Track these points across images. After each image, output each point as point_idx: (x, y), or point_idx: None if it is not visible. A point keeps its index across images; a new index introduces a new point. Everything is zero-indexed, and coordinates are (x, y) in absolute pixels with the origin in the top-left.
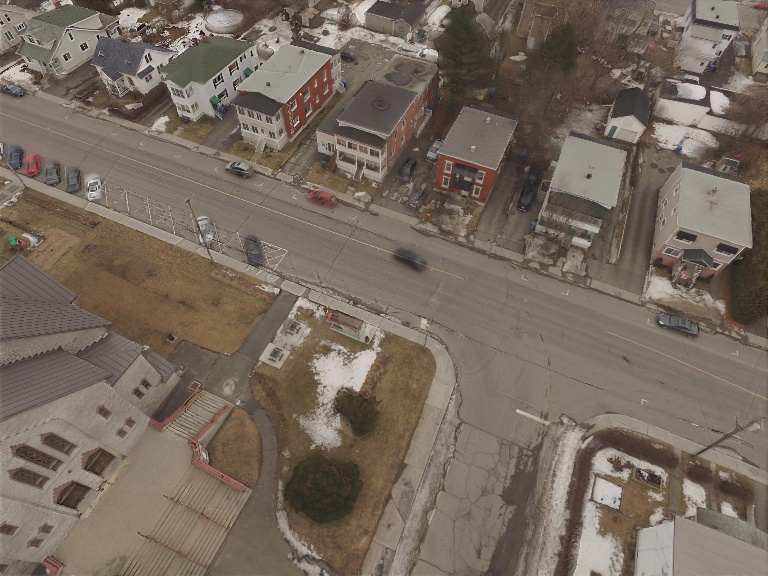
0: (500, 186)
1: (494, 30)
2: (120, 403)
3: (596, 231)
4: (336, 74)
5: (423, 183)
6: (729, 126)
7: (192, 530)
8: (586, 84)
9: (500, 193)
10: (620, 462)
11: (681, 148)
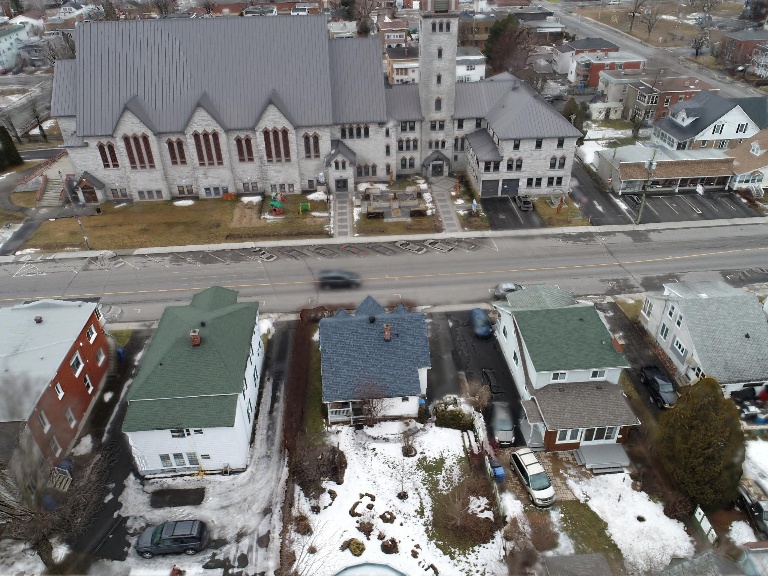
0: None
1: None
2: None
3: None
4: None
5: None
6: None
7: None
8: None
9: None
10: None
11: None
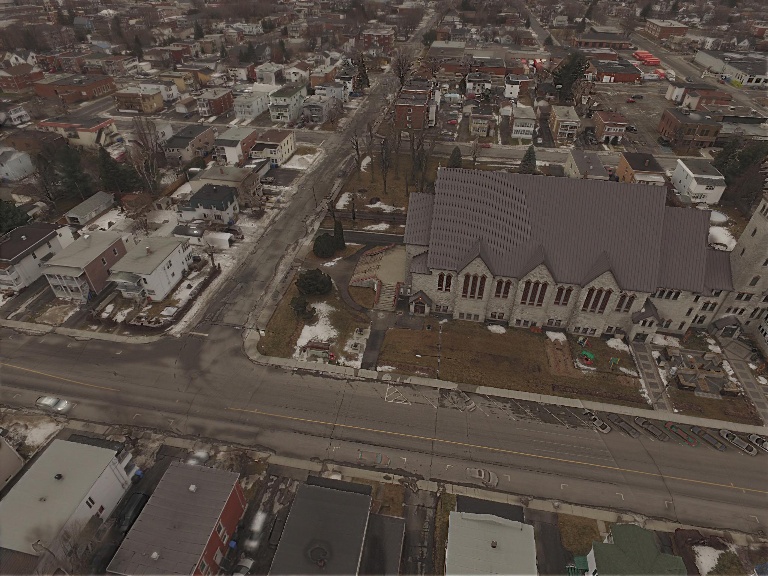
0: None
1: None
2: None
3: None
4: None
5: (261, 515)
6: None
7: None
8: None
9: None
10: (154, 323)
11: None
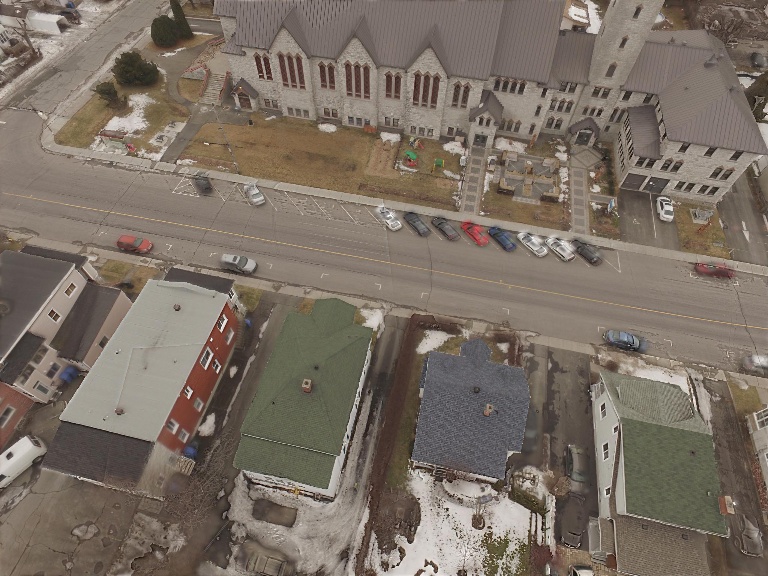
0: None
1: None
2: None
3: None
4: None
5: None
6: None
7: None
8: None
9: None
10: None
11: None
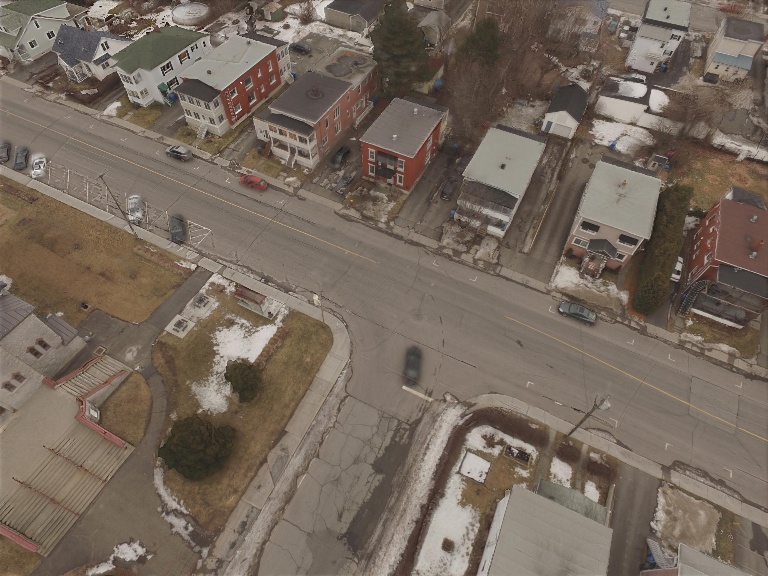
0: (428, 176)
1: (450, 27)
2: (4, 357)
3: (507, 220)
4: (284, 65)
5: (354, 171)
6: (666, 124)
7: (69, 480)
8: (533, 81)
9: (427, 182)
10: (494, 439)
11: (614, 144)
